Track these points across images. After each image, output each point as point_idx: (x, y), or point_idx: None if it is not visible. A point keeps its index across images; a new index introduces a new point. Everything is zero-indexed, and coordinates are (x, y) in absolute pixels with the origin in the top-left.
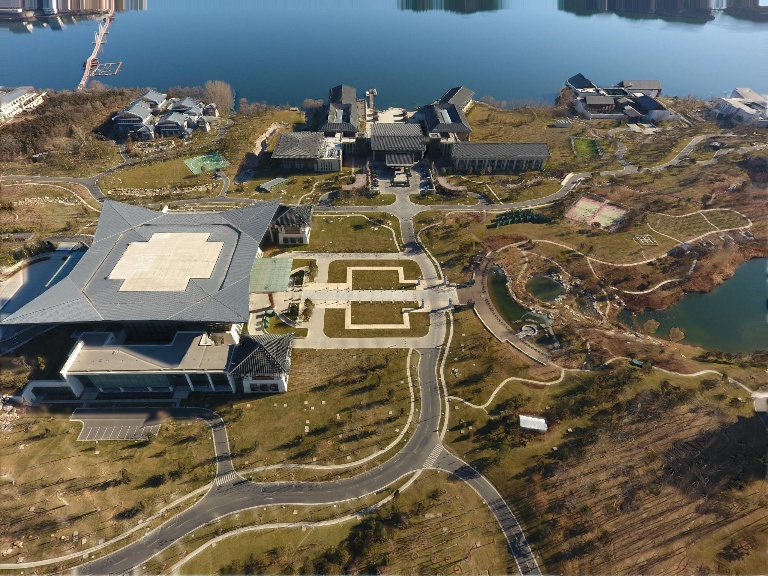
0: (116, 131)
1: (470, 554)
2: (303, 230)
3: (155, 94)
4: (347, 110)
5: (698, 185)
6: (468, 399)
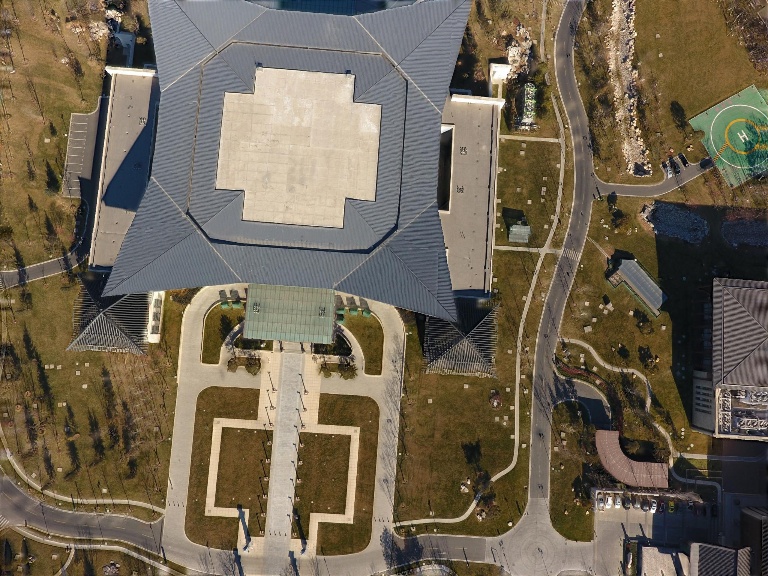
0: None
1: None
2: None
3: None
4: None
5: None
6: (64, 575)
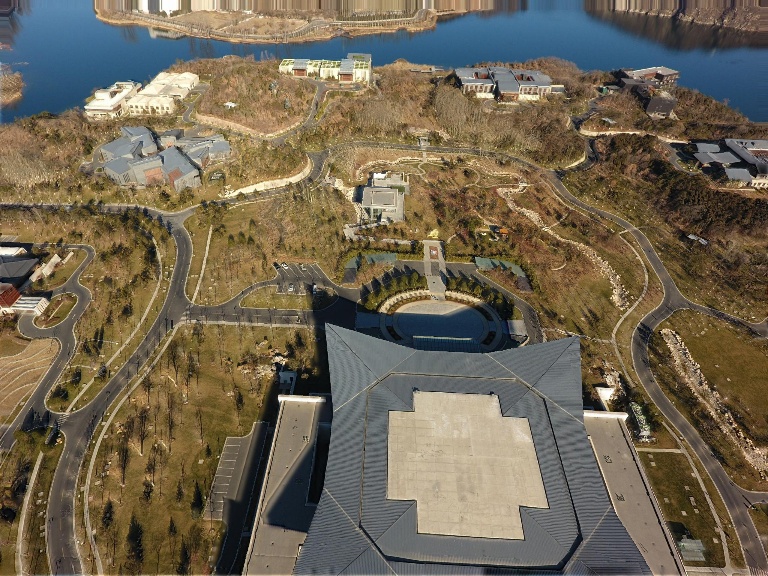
0: None
1: None
2: None
3: None
4: None
5: None
6: None
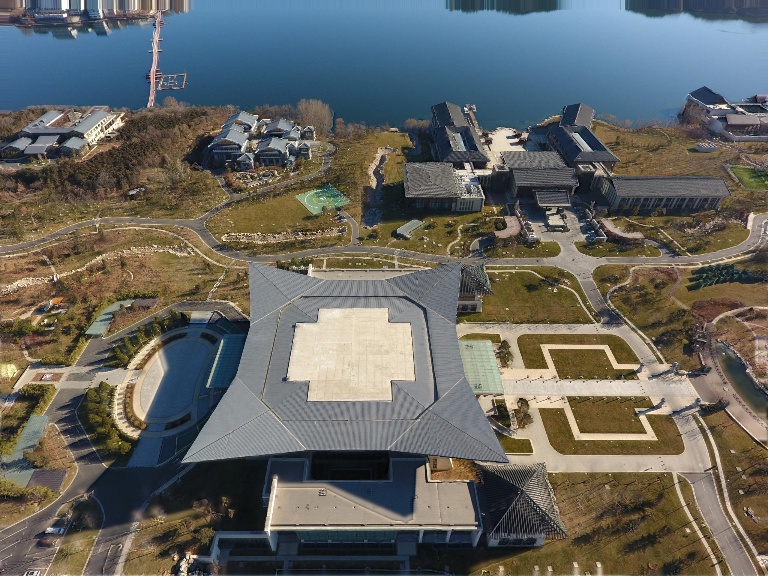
0: (208, 158)
1: None
2: (479, 296)
3: (246, 115)
4: (466, 134)
5: None
6: None
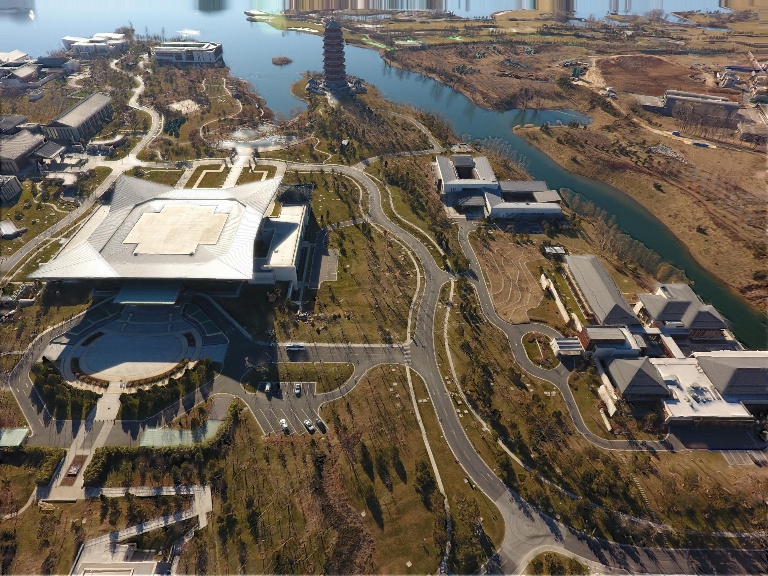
0: None
1: None
2: None
3: None
4: None
5: (176, 78)
6: (326, 158)
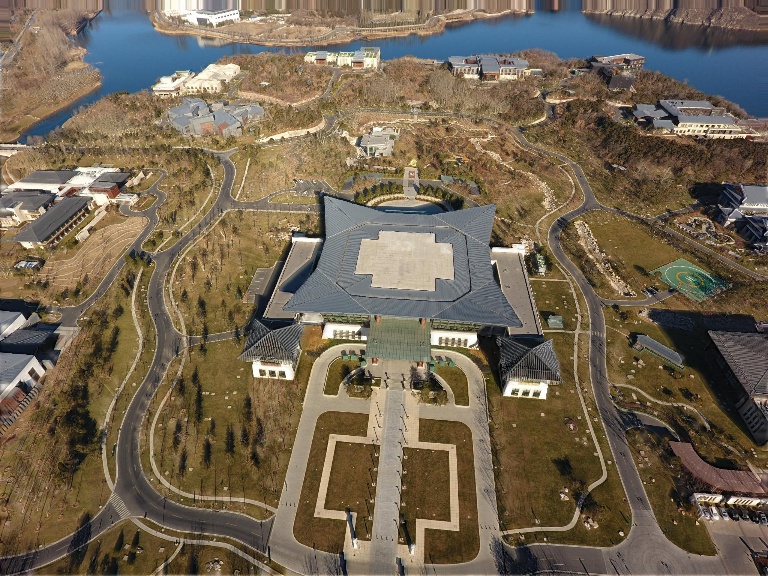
0: None
1: (6, 511)
2: None
3: None
4: None
5: None
6: (166, 570)
